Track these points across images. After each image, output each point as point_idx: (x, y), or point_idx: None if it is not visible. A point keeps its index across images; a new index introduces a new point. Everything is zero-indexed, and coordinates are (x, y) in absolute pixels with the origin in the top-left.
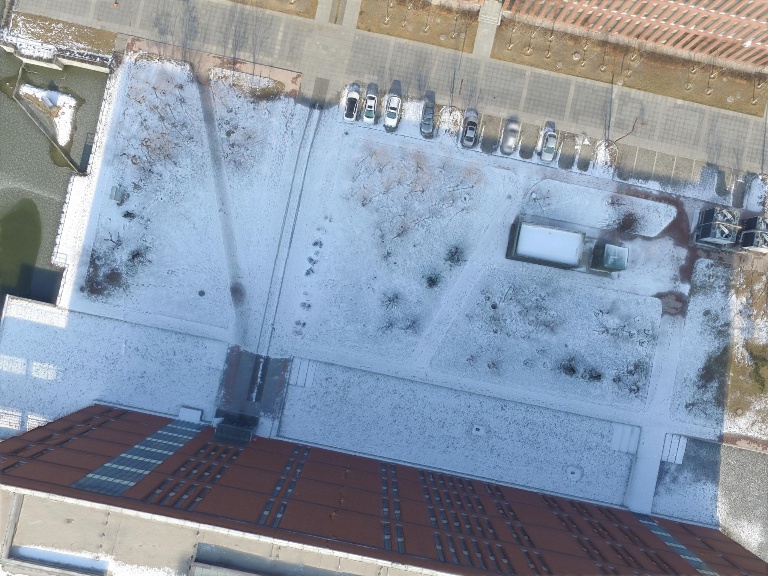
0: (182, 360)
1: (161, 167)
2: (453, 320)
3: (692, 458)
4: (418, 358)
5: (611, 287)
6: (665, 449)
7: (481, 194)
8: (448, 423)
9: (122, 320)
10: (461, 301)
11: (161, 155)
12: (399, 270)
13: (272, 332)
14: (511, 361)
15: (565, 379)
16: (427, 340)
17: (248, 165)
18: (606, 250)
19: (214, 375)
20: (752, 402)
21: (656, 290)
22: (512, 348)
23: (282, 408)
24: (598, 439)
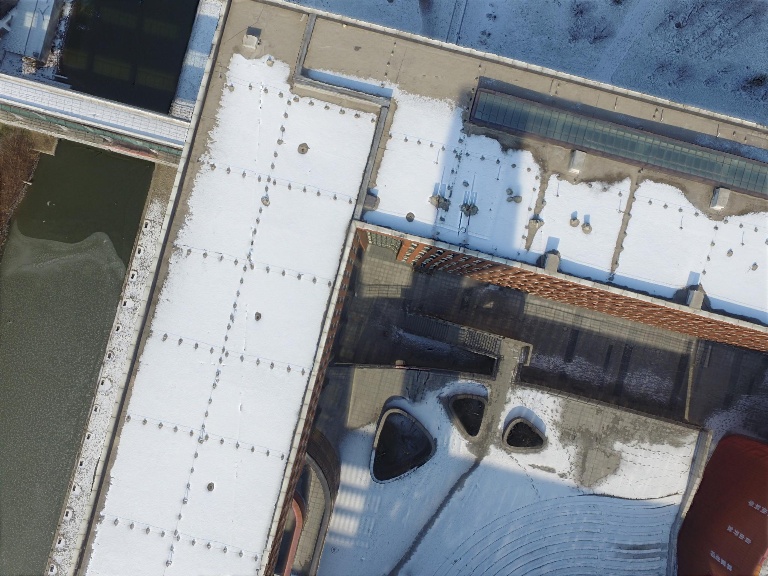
0: None
1: None
2: (635, 38)
3: None
4: (600, 73)
5: None
6: None
7: None
8: None
9: None
10: (644, 20)
11: None
12: None
13: (457, 41)
14: (691, 81)
15: (745, 101)
16: (609, 56)
17: None
18: None
19: None
20: None
21: None
22: (693, 68)
23: None
24: None
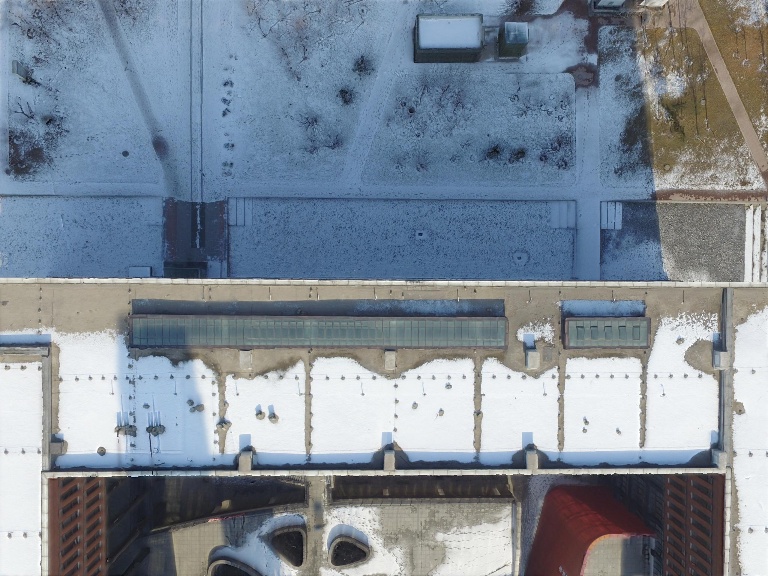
0: (121, 223)
1: (58, 36)
2: (375, 132)
3: (630, 221)
4: (349, 176)
5: (522, 71)
6: (603, 217)
7: (378, 4)
8: (391, 233)
9: (54, 195)
10: (379, 113)
11: (55, 24)
12: (312, 93)
13: (202, 178)
14: (439, 161)
15: (494, 168)
16: (354, 156)
17: (143, 18)
18: (506, 28)
19: (155, 232)
20: (677, 156)
21: (565, 65)
22: (437, 148)
23: (227, 250)
24: (537, 221)
